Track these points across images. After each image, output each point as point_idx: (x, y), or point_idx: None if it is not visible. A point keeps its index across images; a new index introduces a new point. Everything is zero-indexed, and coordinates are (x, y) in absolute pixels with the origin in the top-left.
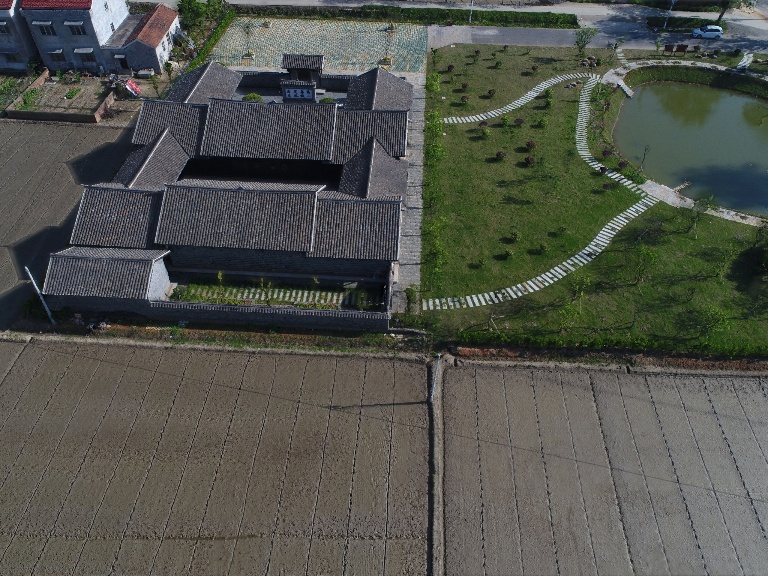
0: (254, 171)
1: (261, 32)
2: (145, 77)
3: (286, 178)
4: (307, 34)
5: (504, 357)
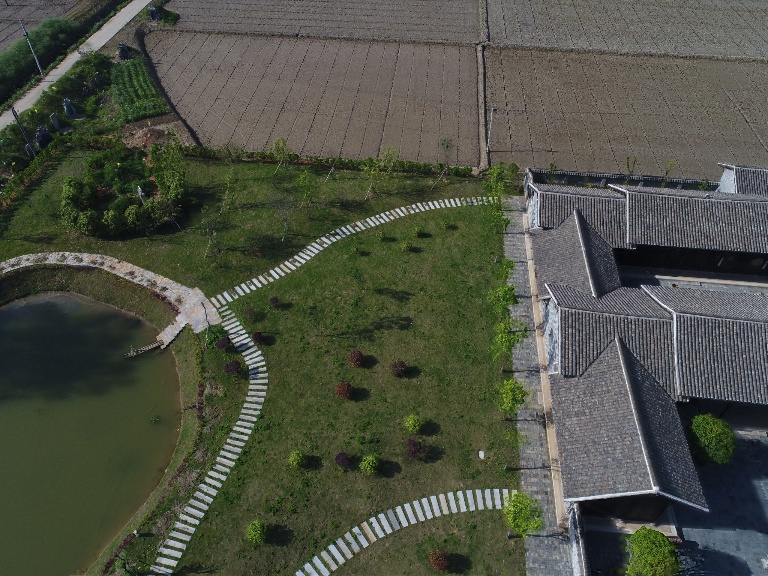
0: None
1: None
2: None
3: None
4: None
5: None
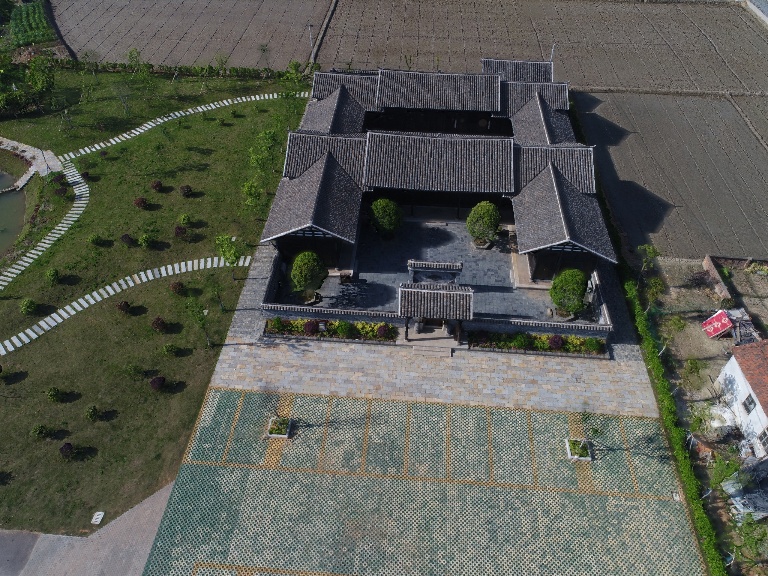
0: None
1: None
2: None
3: None
4: None
5: None
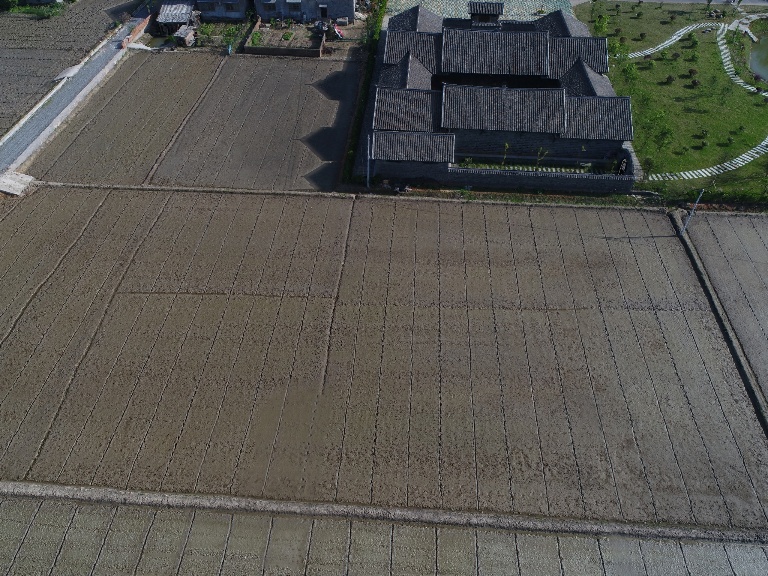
0: None
1: None
2: (342, 24)
3: None
4: None
5: (724, 210)
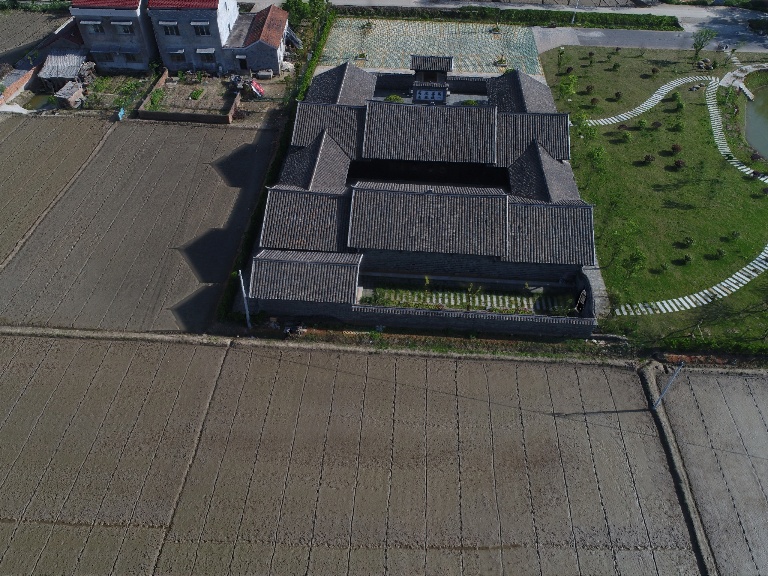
0: (410, 174)
1: (366, 33)
2: (264, 78)
3: (441, 181)
4: (413, 35)
5: (712, 364)
